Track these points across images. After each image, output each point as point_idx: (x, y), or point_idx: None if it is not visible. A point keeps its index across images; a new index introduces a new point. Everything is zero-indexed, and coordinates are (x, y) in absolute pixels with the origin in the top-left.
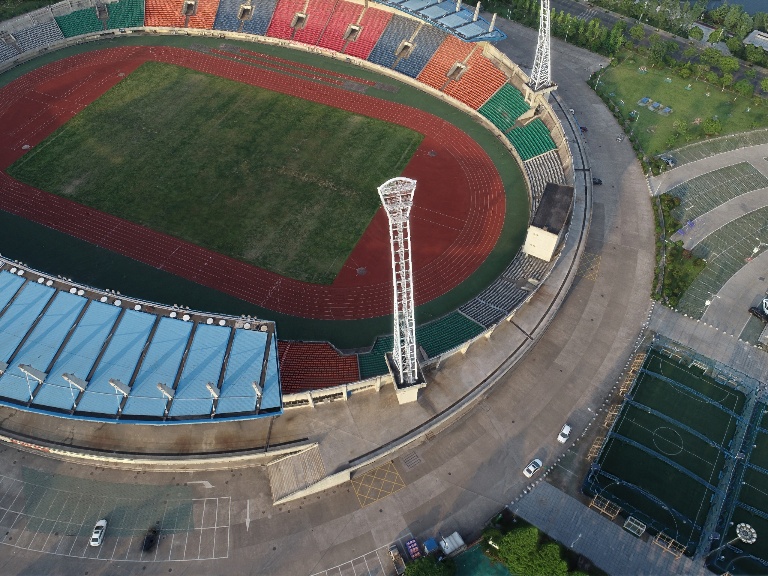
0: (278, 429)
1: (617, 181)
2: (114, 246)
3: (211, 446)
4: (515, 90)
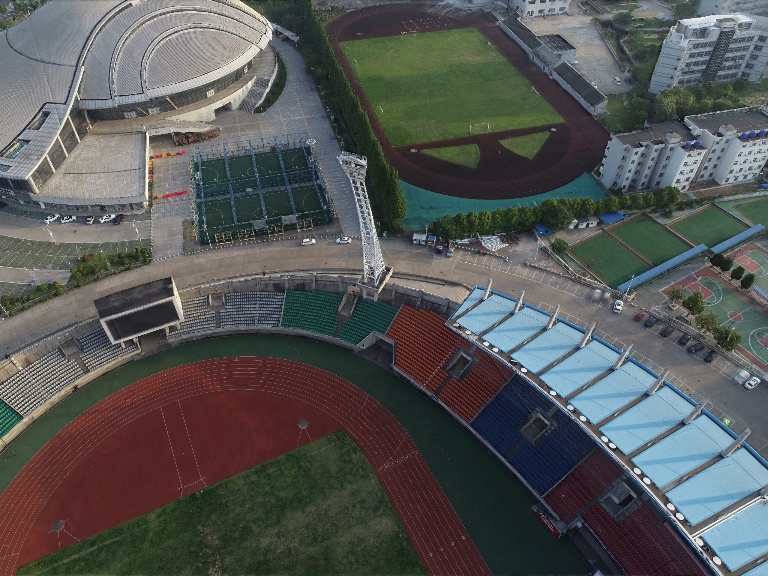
0: None
1: None
2: None
3: None
4: None
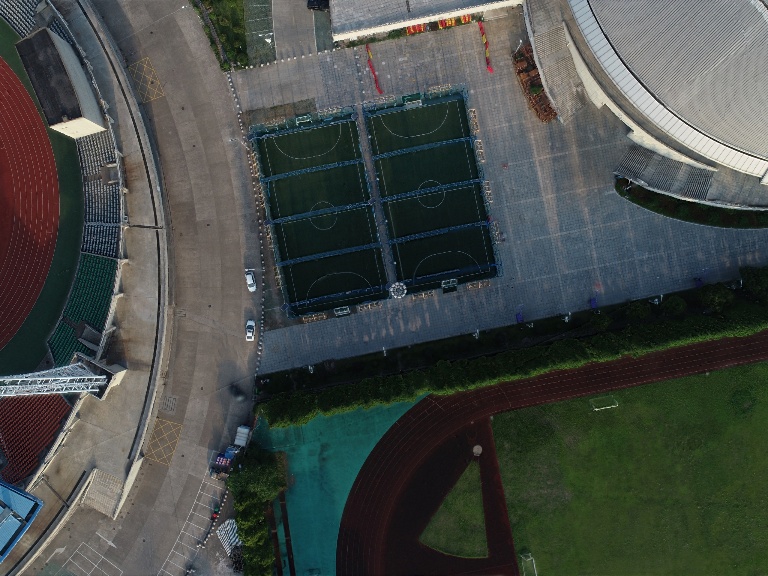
0: (58, 485)
1: None
2: None
3: (29, 540)
4: None
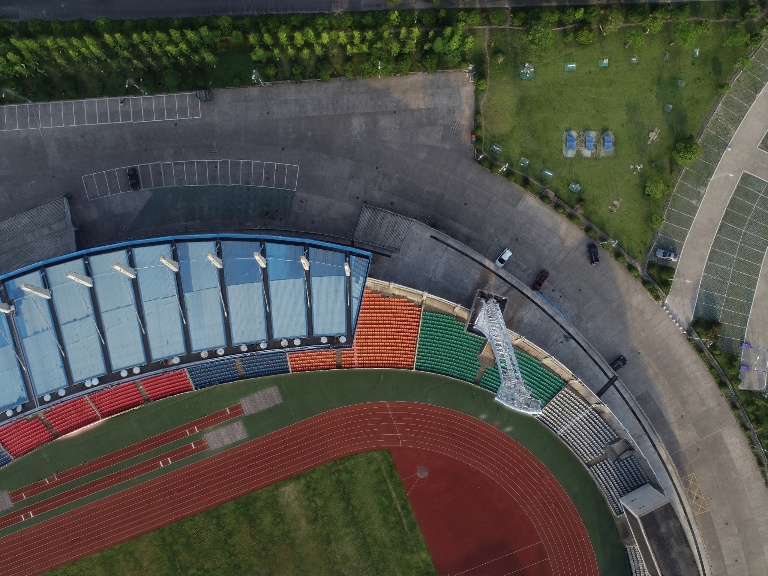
0: None
1: (637, 340)
2: None
3: None
4: (443, 317)
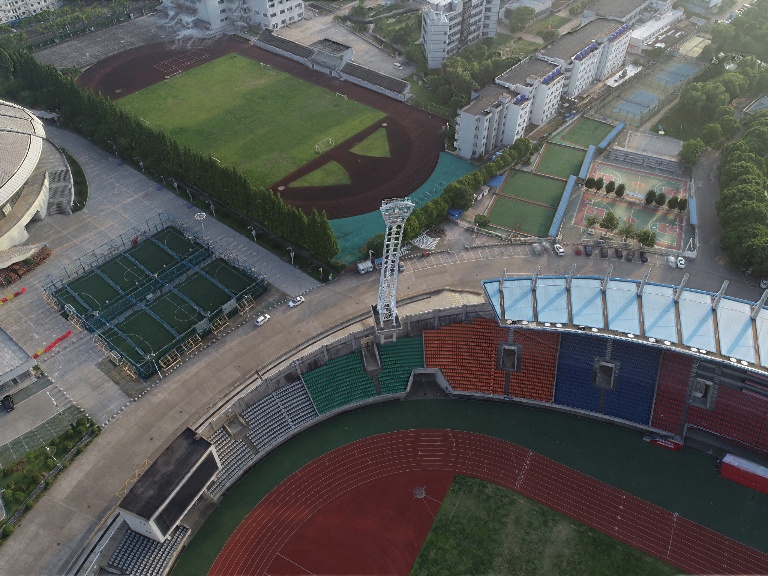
0: None
1: None
2: (760, 559)
3: None
4: None
